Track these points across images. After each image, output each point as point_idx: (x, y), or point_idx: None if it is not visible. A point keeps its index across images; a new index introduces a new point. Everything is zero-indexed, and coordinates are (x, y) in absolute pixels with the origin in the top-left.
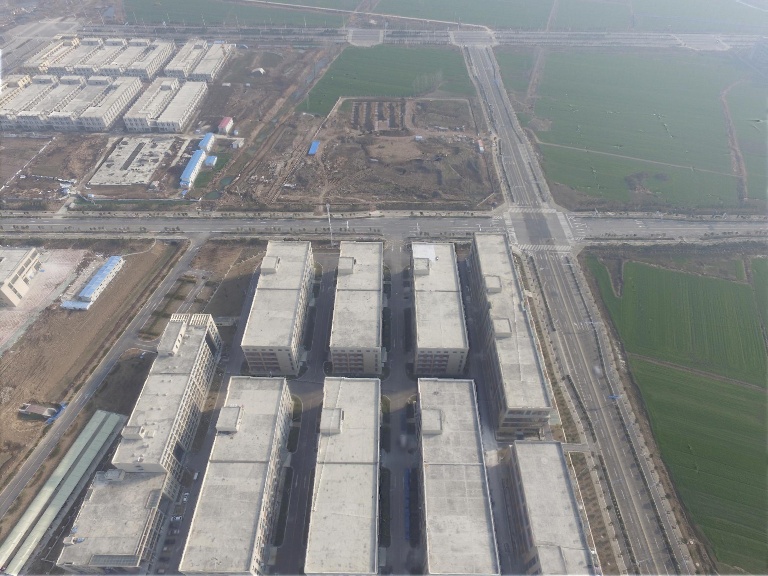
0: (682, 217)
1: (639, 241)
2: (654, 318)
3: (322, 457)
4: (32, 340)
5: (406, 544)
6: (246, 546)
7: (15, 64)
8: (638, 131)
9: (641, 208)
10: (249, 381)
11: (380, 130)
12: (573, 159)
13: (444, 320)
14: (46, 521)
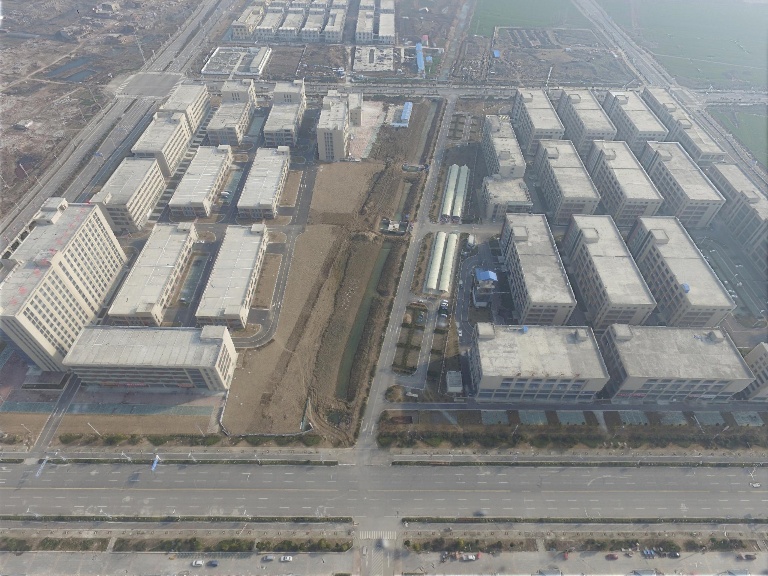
0: (767, 93)
1: (742, 104)
2: (763, 137)
3: (611, 167)
4: (384, 140)
5: (657, 213)
6: (592, 192)
7: None
8: (723, 49)
9: (739, 88)
10: (550, 141)
11: (537, 45)
12: (682, 63)
13: (647, 121)
14: (460, 200)
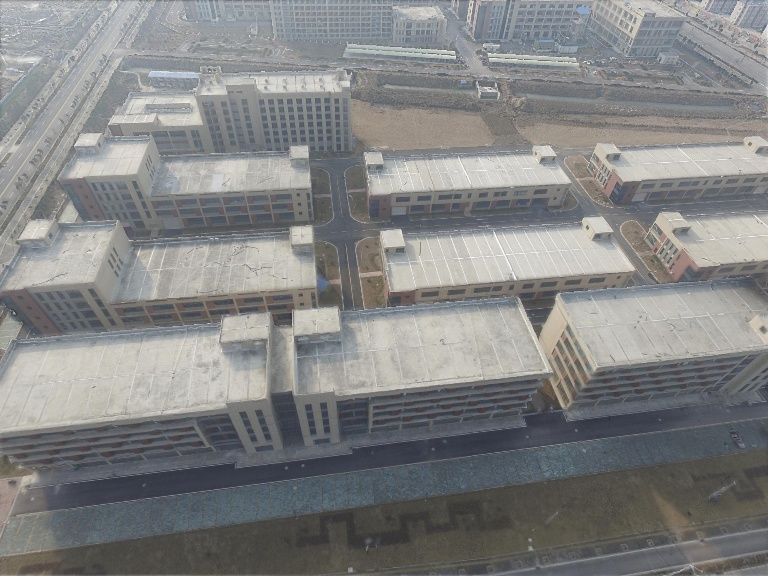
0: None
1: None
2: None
3: None
4: None
5: None
6: None
7: None
8: None
9: None
10: None
11: None
12: None
13: None
14: None
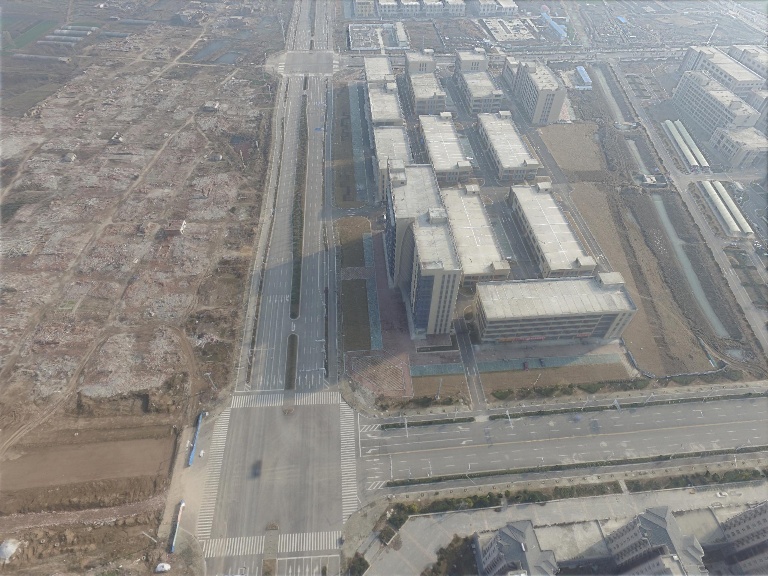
0: None
1: None
2: None
3: None
4: (578, 102)
5: None
6: None
7: None
8: None
9: None
10: None
11: (652, 11)
12: None
13: None
14: None
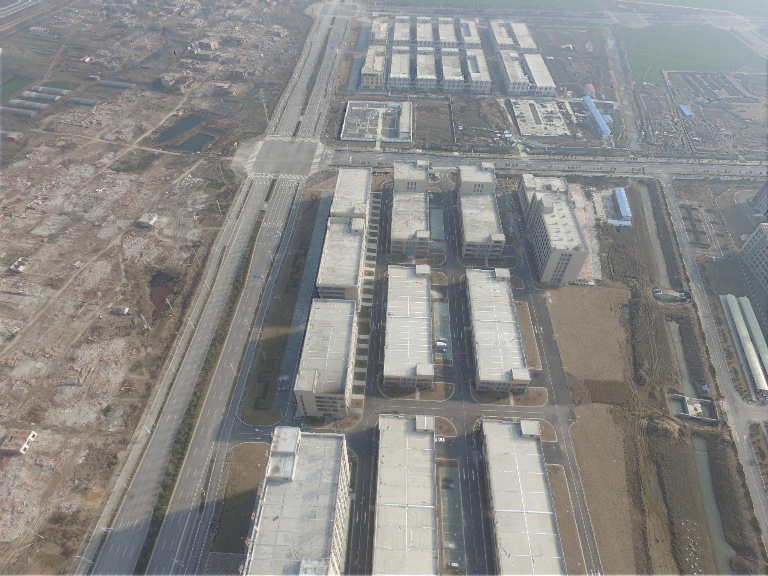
0: None
1: None
2: None
3: None
4: (608, 247)
5: None
6: None
7: (372, 36)
8: None
9: None
10: None
11: (727, 97)
12: None
13: None
14: None
